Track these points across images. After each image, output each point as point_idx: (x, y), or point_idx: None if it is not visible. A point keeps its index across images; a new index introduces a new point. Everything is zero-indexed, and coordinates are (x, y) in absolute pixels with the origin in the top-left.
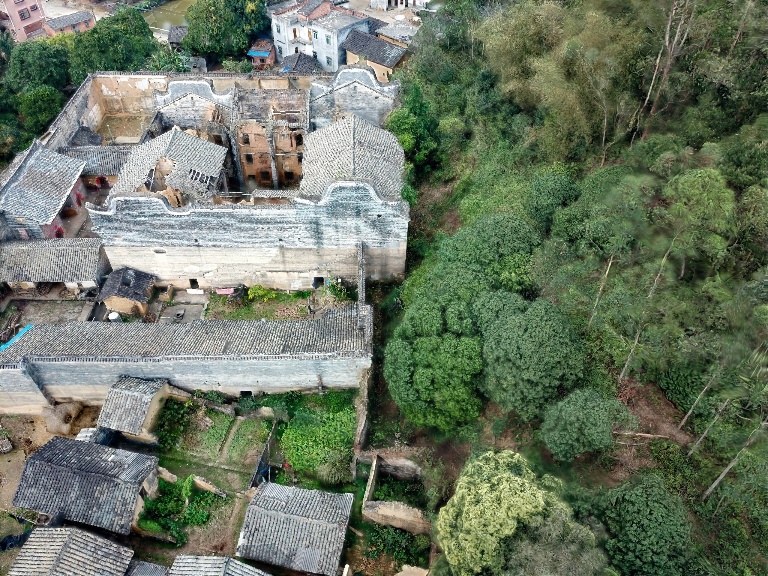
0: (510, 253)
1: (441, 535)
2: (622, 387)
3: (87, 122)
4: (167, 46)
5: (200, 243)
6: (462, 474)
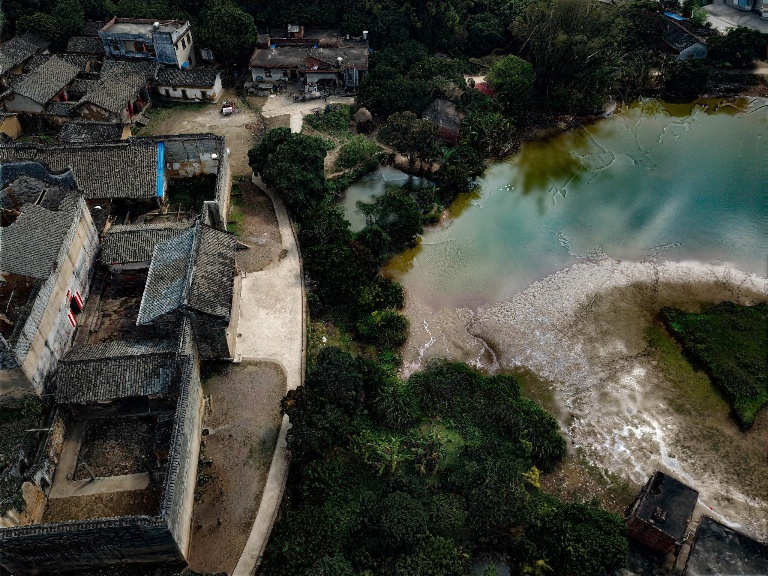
0: None
1: None
2: None
3: None
4: None
5: None
6: None
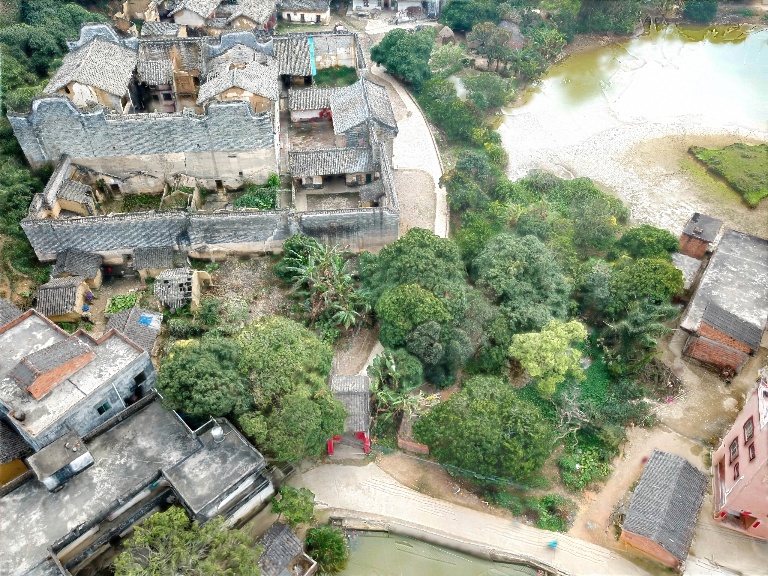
0: None
1: None
2: (6, 8)
3: None
4: (375, 391)
5: None
6: None
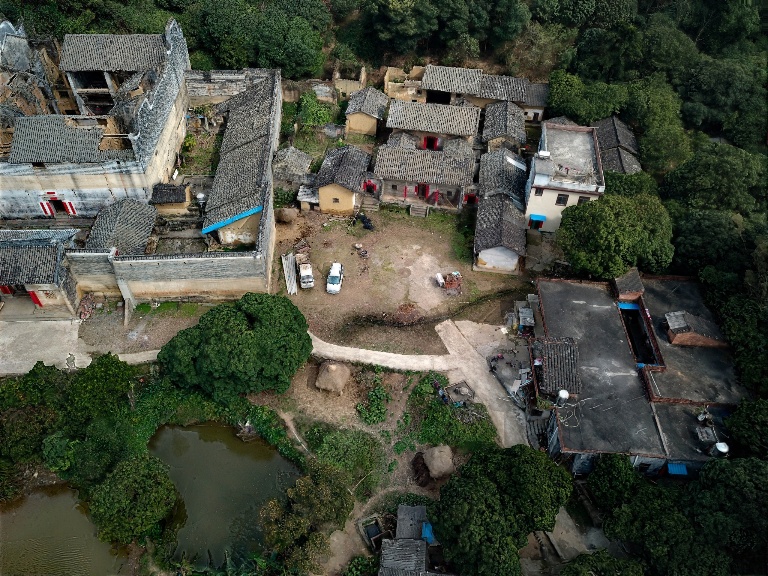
0: (235, 6)
1: (400, 7)
2: None
3: None
4: None
5: (161, 128)
6: (375, 6)
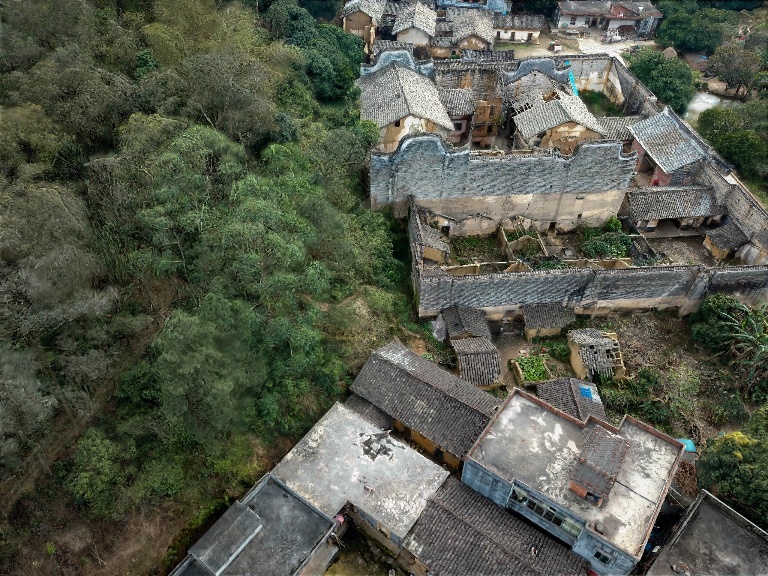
0: None
1: None
2: None
3: (759, 258)
4: None
5: None
6: None
